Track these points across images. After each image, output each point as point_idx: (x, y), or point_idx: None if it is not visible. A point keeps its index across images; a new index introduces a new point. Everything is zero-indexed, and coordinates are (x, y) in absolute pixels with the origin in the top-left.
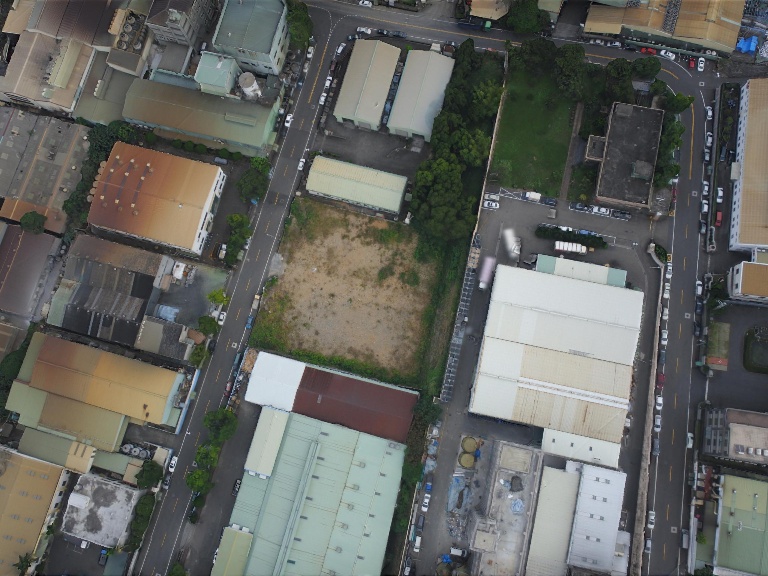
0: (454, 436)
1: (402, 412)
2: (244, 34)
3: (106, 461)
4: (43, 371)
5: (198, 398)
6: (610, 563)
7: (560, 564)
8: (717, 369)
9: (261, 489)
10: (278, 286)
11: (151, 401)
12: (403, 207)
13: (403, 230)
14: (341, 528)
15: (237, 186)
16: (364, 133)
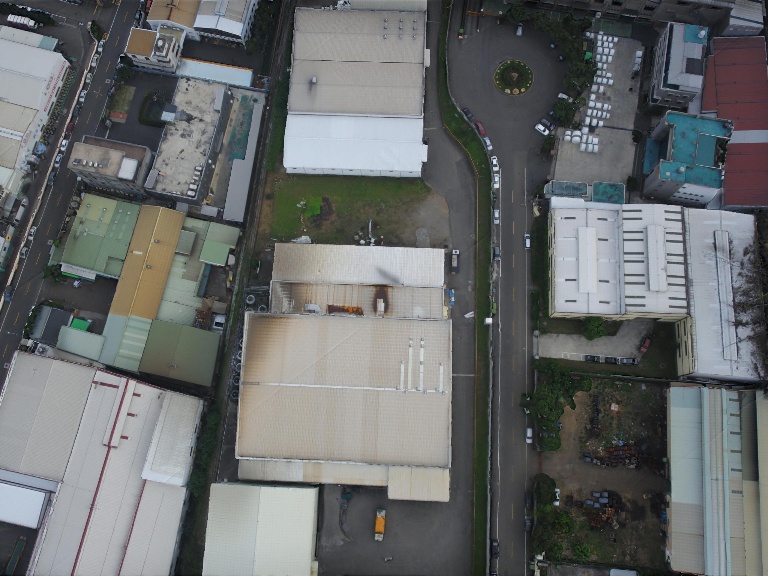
0: None
1: None
2: None
3: None
4: None
5: None
6: None
7: None
8: (117, 121)
9: None
10: None
11: None
12: None
13: None
14: None
15: None
16: None
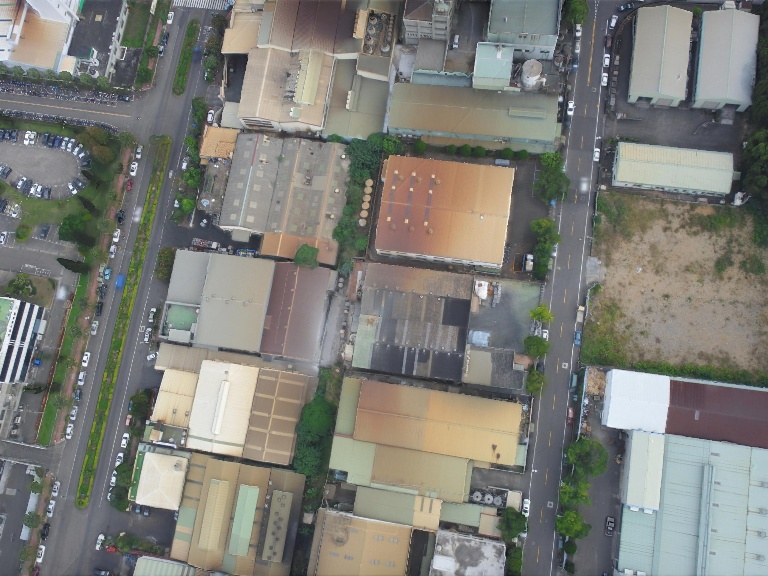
0: None
1: None
2: (523, 17)
3: (455, 514)
4: (367, 421)
5: (537, 430)
6: None
7: None
8: None
9: (649, 526)
10: (602, 293)
11: (500, 440)
12: None
13: (734, 213)
14: (755, 560)
15: (537, 187)
16: (661, 111)
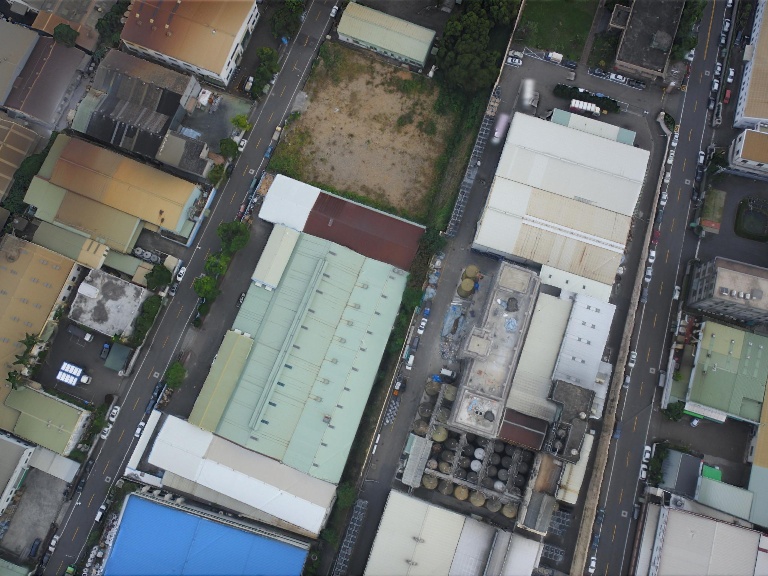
0: (455, 269)
1: (408, 242)
2: None
3: (117, 261)
4: (64, 169)
5: (212, 216)
6: (592, 383)
7: (545, 380)
8: (709, 231)
9: (266, 300)
10: (300, 121)
11: (168, 207)
12: (428, 61)
13: (426, 82)
14: (339, 342)
15: (270, 21)
16: None
